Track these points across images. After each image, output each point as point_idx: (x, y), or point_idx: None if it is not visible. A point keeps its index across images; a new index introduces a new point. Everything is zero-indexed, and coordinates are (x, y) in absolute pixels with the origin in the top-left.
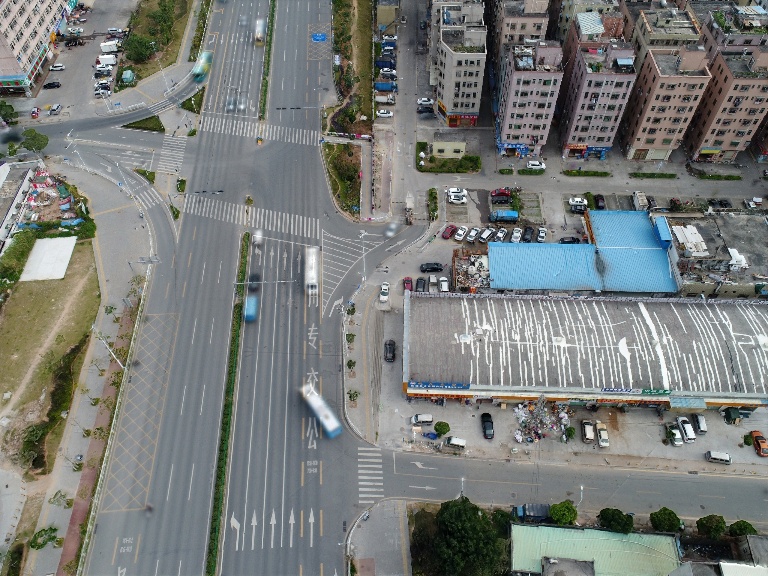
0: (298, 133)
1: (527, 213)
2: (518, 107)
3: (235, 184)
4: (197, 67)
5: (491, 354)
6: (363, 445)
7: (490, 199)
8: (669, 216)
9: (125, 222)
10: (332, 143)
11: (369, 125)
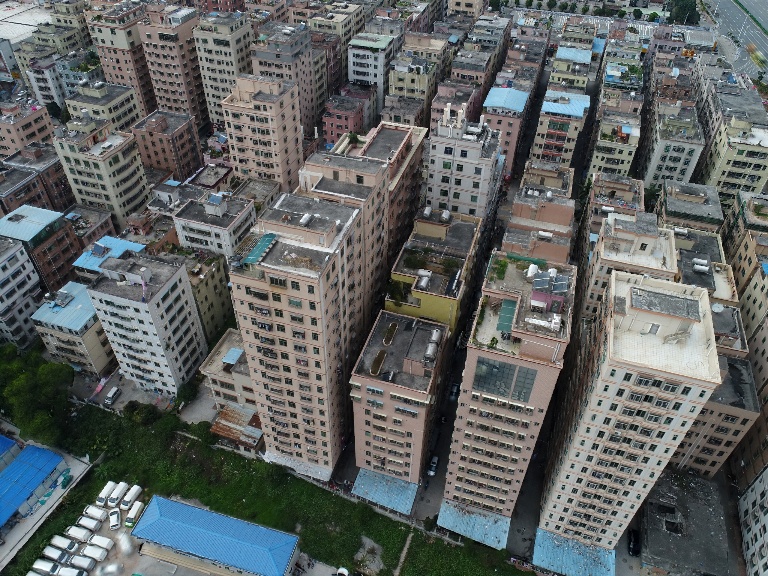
0: None
1: None
2: None
3: None
4: None
5: None
6: None
7: None
8: None
9: None
10: None
11: None
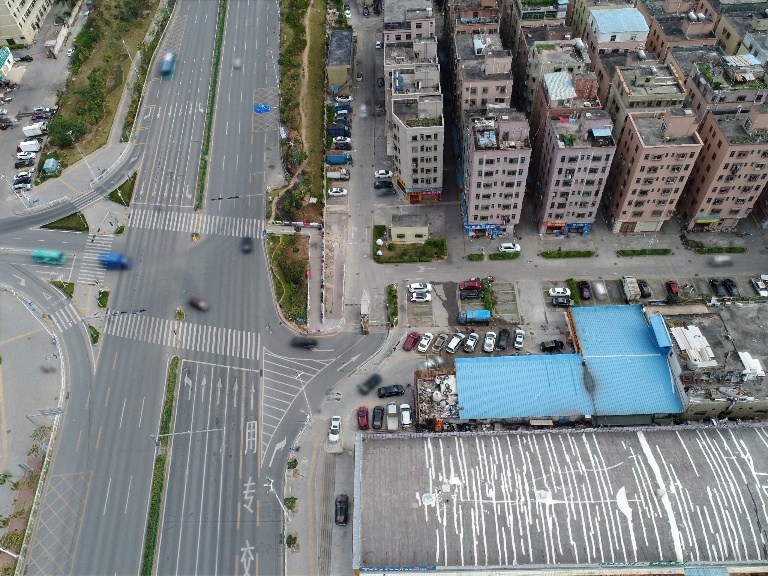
0: (239, 223)
1: (501, 310)
2: (483, 187)
3: (165, 293)
4: (129, 148)
5: (461, 520)
6: None
7: (458, 294)
8: (666, 310)
9: (35, 351)
10: (277, 234)
11: (319, 209)
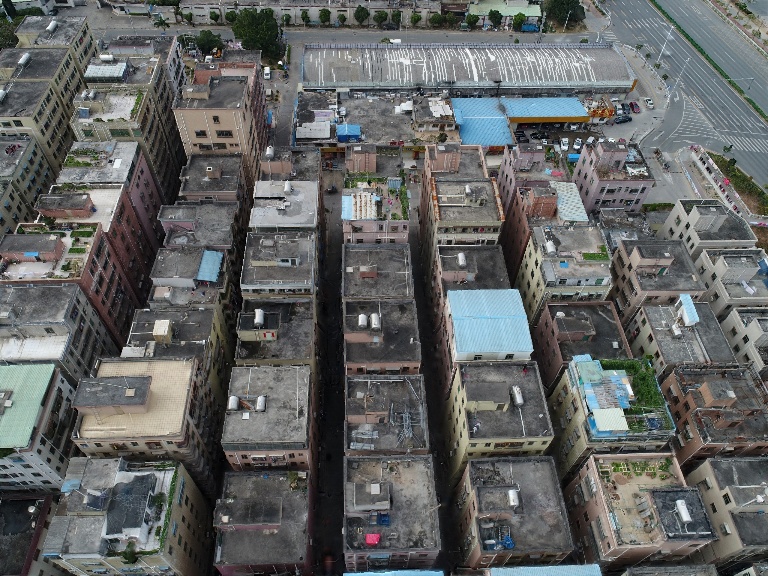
0: None
1: None
2: None
3: None
4: None
5: None
6: (620, 45)
7: None
8: None
9: None
10: None
11: (761, 243)
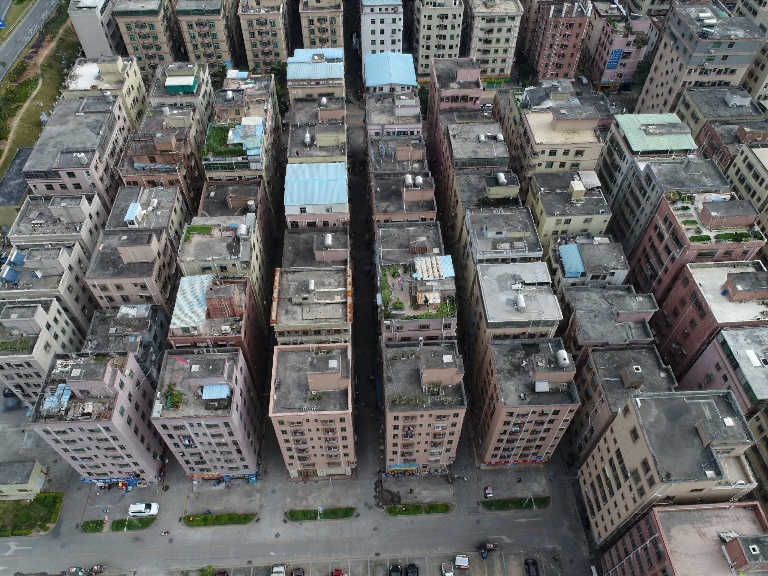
0: None
1: None
2: (74, 451)
3: None
4: None
5: None
6: None
7: None
8: None
9: None
10: None
11: None
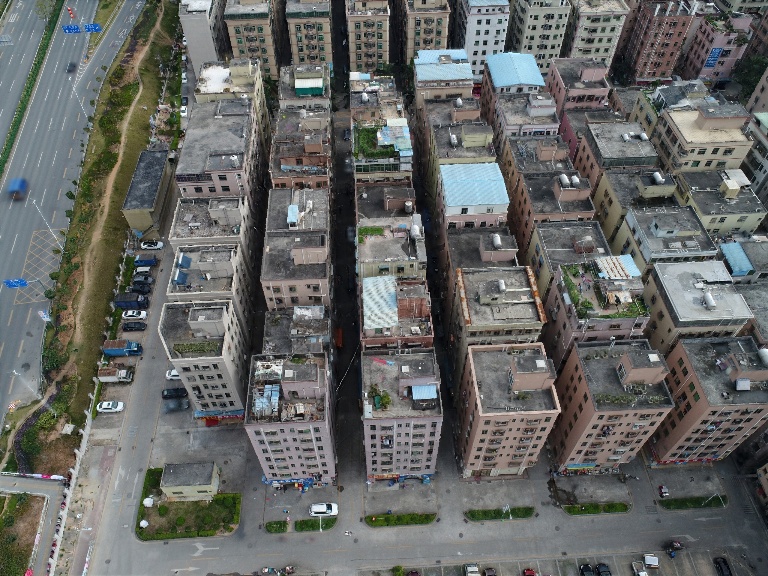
0: None
1: None
2: (272, 452)
3: None
4: None
5: None
6: None
7: None
8: None
9: None
10: (3, 493)
11: (72, 446)
